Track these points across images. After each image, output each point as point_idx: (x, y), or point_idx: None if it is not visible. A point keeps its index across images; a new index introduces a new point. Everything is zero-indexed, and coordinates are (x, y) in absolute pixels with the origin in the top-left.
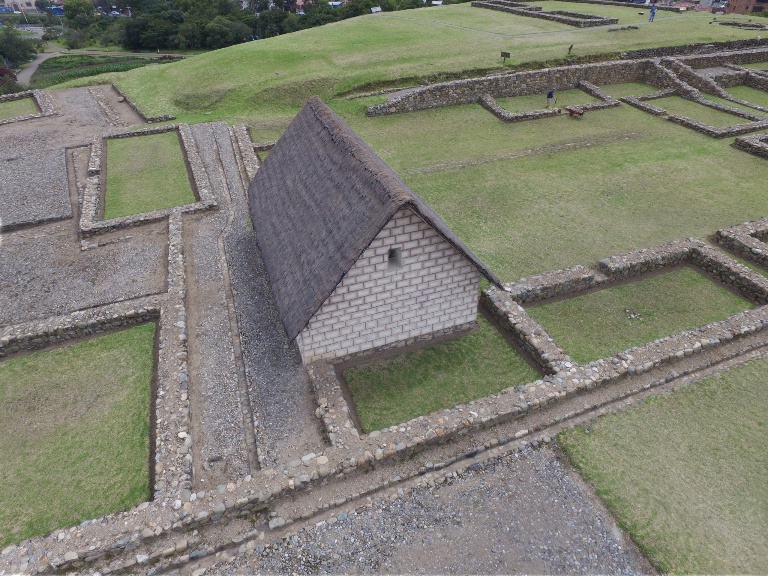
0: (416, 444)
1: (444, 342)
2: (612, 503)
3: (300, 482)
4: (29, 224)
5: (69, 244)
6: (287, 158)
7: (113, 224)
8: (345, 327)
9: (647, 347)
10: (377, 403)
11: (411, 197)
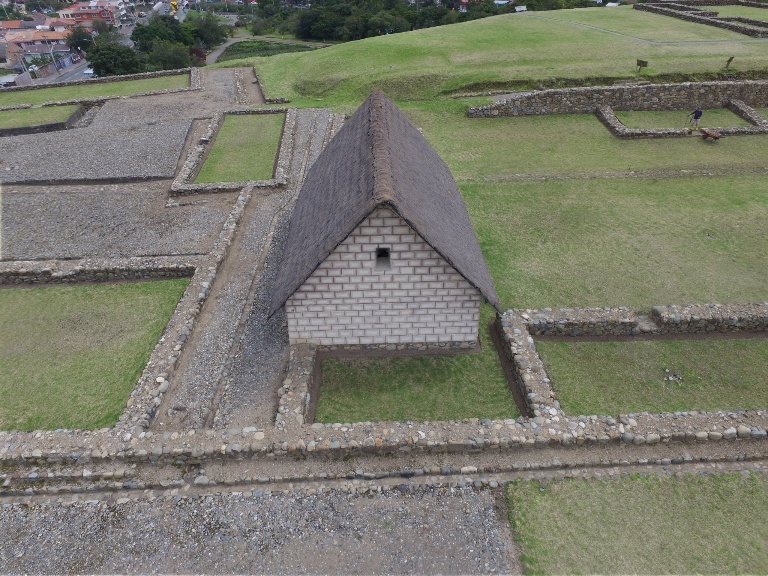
0: (350, 447)
1: (436, 355)
2: (533, 575)
3: (231, 450)
4: (140, 179)
5: (160, 200)
6: (337, 147)
7: (196, 188)
8: (330, 317)
9: (661, 416)
10: (341, 398)
11: (392, 197)
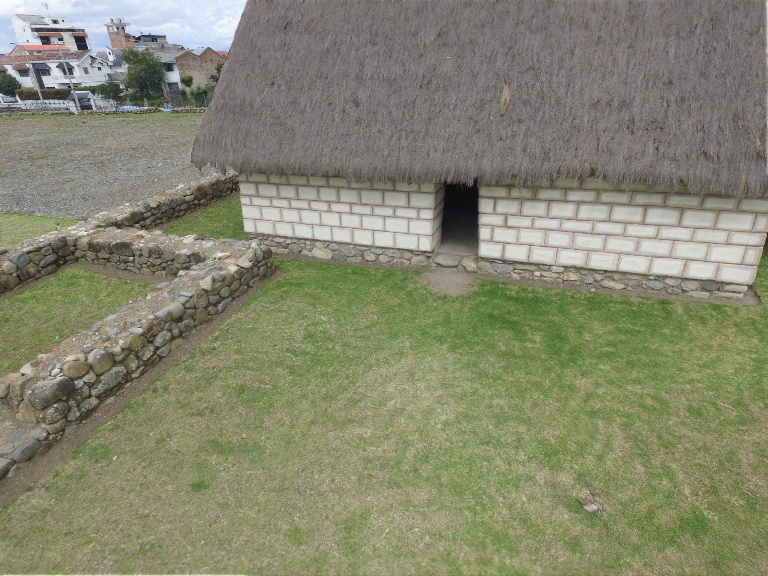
0: None
1: None
2: None
3: None
4: None
5: None
6: None
7: None
8: None
9: None
10: None
11: None
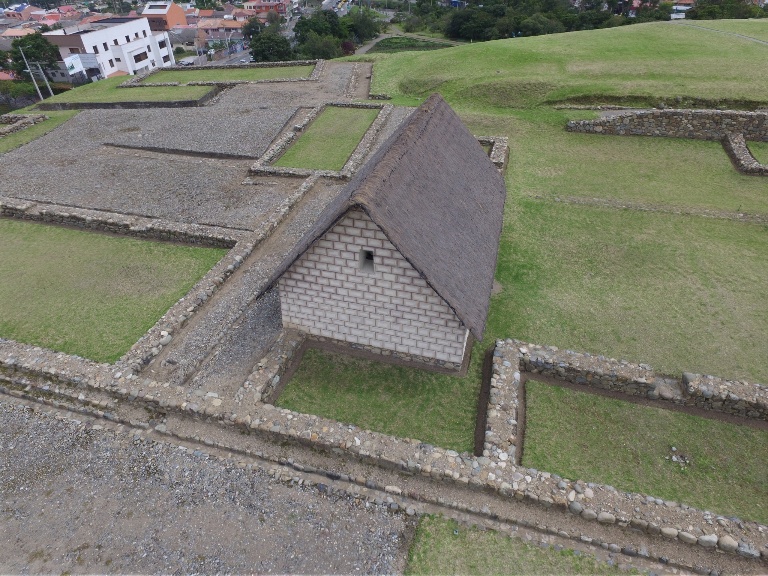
0: (288, 435)
1: (416, 369)
2: None
3: (189, 408)
4: (233, 156)
5: (240, 177)
6: None
7: (271, 170)
8: (318, 309)
9: (627, 496)
10: (308, 388)
11: (367, 201)
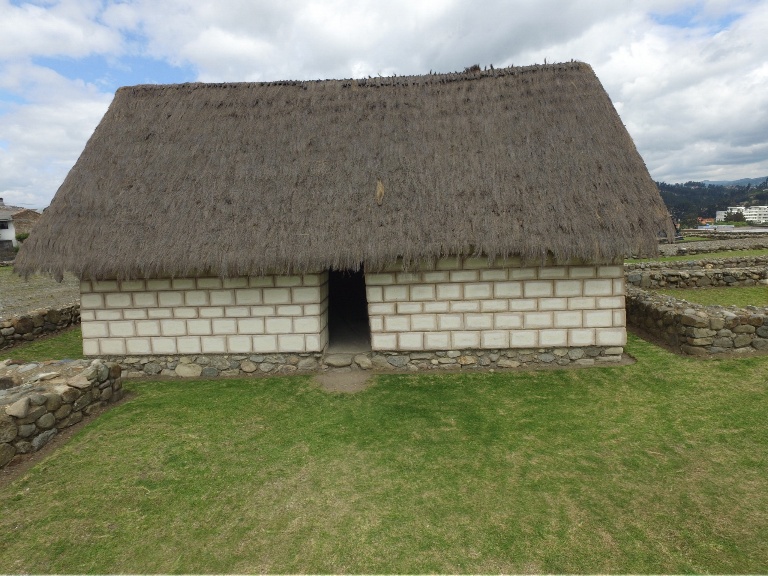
0: None
1: None
2: None
3: None
4: None
5: None
6: None
7: None
8: None
9: None
10: None
11: (125, 87)
